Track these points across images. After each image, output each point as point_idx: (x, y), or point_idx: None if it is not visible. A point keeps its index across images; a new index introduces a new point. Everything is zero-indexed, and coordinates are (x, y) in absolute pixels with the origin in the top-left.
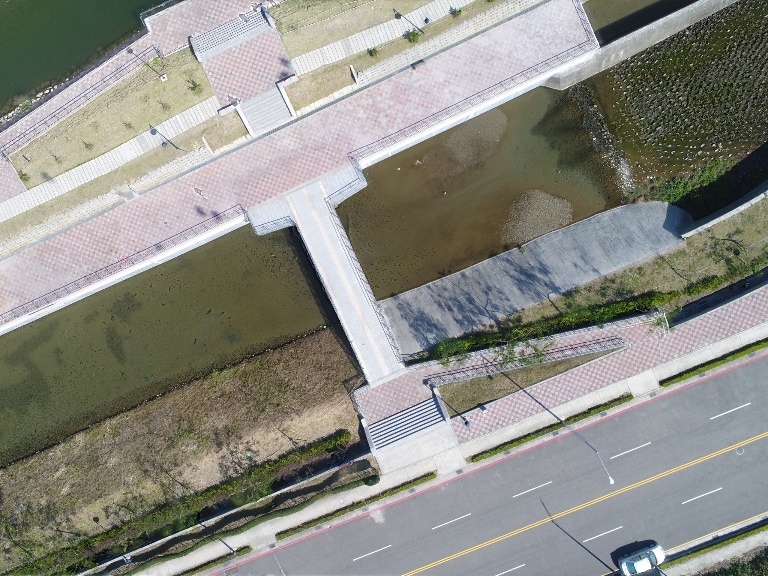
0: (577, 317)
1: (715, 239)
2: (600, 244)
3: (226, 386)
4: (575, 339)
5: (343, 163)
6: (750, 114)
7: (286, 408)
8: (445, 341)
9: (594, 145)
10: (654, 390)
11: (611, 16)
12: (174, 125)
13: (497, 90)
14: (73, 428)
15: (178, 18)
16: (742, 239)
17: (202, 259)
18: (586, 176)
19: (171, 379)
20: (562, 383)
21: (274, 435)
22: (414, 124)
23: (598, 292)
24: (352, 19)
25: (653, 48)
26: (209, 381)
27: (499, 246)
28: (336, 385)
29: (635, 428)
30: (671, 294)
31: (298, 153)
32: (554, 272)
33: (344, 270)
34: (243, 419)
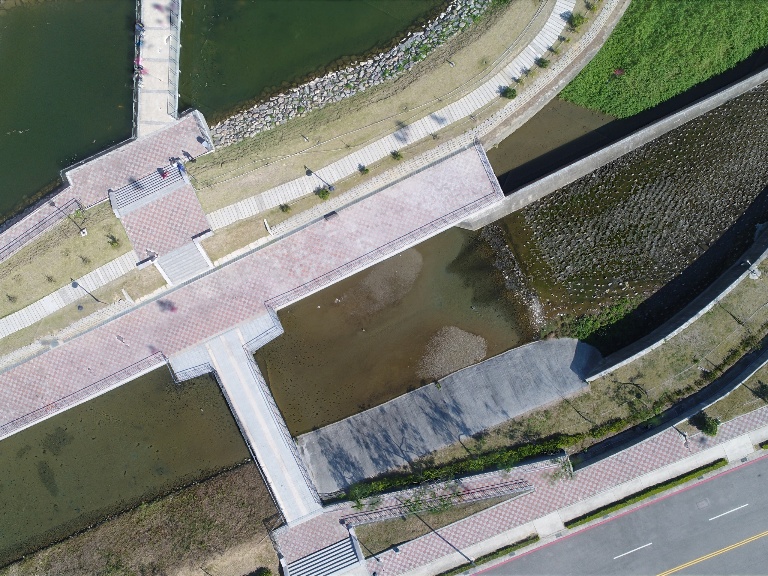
0: (486, 460)
1: (618, 383)
2: (511, 384)
3: (154, 520)
4: (484, 482)
5: (260, 311)
6: (655, 254)
7: (209, 546)
8: (361, 481)
9: (506, 283)
10: (560, 531)
11: (522, 158)
12: (94, 278)
13: (407, 240)
14: (8, 559)
15: (98, 172)
16: (643, 383)
17: (130, 394)
18: (499, 313)
19: (102, 511)
20: (471, 525)
21: (197, 574)
22: (328, 273)
23: (507, 434)
24: (265, 176)
25: (561, 190)
26: (138, 514)
27: (416, 381)
28: (257, 524)
29: (542, 567)
30: (576, 437)
31: (216, 302)
32: (466, 412)
33: (262, 414)
34: (168, 556)
